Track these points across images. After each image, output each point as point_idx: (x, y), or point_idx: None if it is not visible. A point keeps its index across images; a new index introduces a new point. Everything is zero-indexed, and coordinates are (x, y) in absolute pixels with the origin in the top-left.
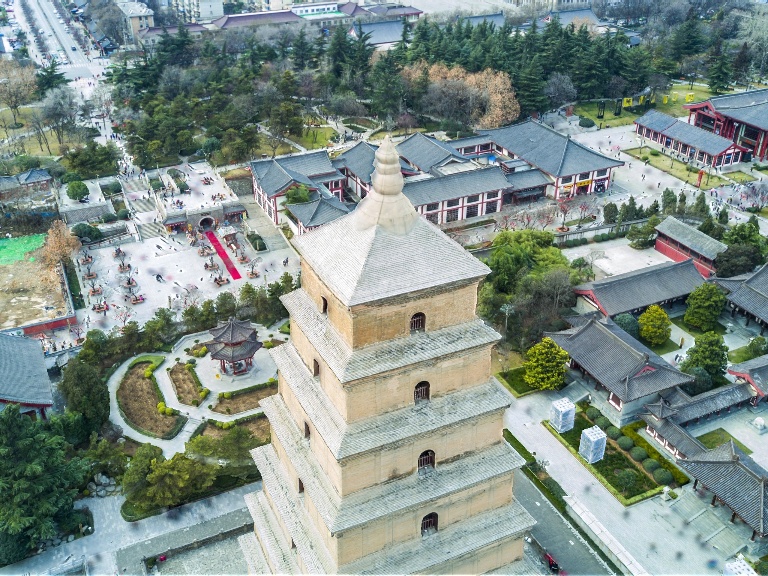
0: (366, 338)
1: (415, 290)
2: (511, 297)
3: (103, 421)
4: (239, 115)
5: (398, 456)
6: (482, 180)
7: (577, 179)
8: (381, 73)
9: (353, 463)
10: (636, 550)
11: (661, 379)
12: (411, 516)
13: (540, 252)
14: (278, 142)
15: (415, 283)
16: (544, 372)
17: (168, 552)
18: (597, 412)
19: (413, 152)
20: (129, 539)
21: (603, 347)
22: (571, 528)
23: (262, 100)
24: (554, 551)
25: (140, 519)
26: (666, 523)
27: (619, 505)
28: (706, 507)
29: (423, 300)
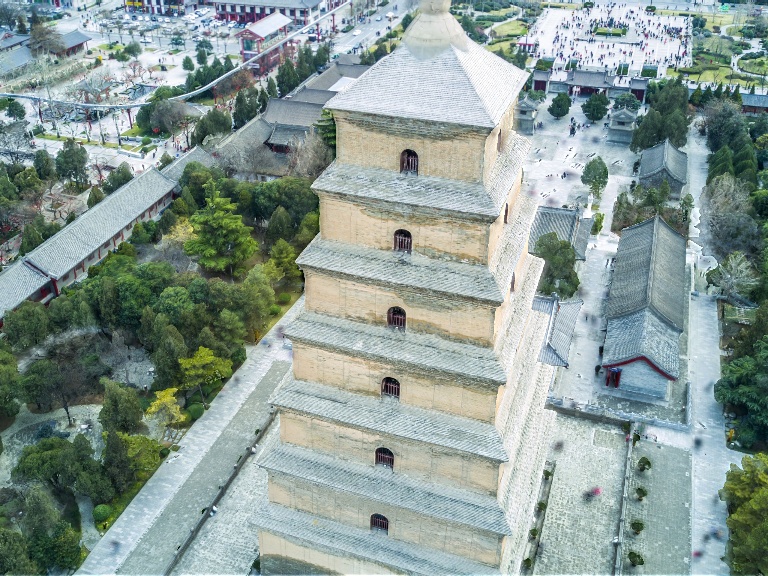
0: None
1: None
2: None
3: None
4: None
5: None
6: None
7: None
8: None
9: None
10: None
11: None
12: None
13: None
14: None
15: None
16: None
17: None
18: None
19: None
20: (702, 464)
21: None
22: None
23: None
24: None
25: None
26: None
27: None
28: None
29: None
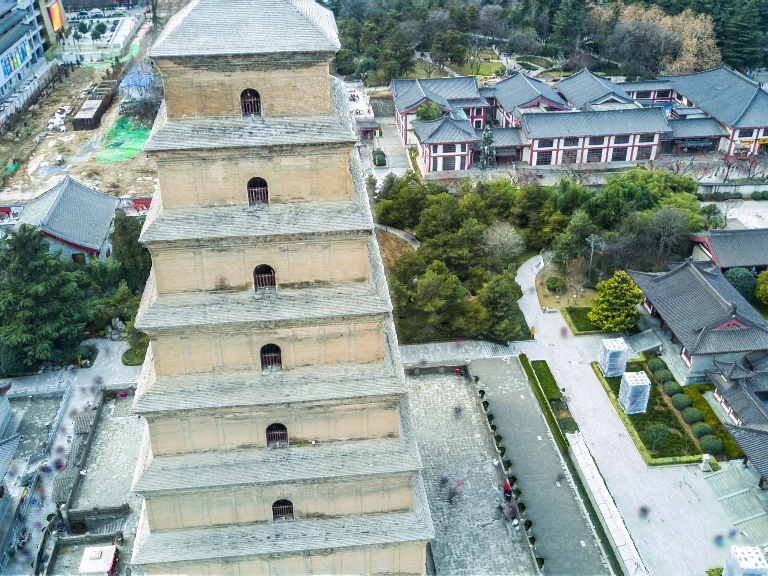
0: (183, 108)
1: (234, 53)
2: (611, 234)
3: (143, 276)
4: (402, 38)
5: (225, 262)
6: (637, 120)
7: (760, 134)
8: (563, 7)
9: (167, 255)
10: (638, 512)
11: (750, 338)
12: (244, 340)
13: (669, 195)
14: (438, 70)
15: (237, 45)
16: (610, 310)
17: (129, 389)
18: (660, 363)
19: (573, 89)
20: (117, 379)
21: (689, 293)
22: (565, 470)
23: (431, 27)
24: (532, 487)
25: (136, 365)
26: (691, 494)
27: (641, 462)
28: (750, 487)
29: (254, 73)
